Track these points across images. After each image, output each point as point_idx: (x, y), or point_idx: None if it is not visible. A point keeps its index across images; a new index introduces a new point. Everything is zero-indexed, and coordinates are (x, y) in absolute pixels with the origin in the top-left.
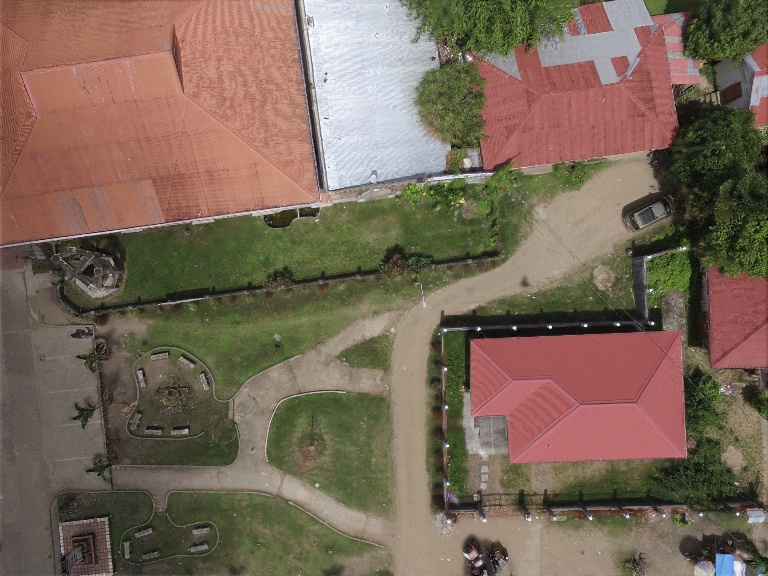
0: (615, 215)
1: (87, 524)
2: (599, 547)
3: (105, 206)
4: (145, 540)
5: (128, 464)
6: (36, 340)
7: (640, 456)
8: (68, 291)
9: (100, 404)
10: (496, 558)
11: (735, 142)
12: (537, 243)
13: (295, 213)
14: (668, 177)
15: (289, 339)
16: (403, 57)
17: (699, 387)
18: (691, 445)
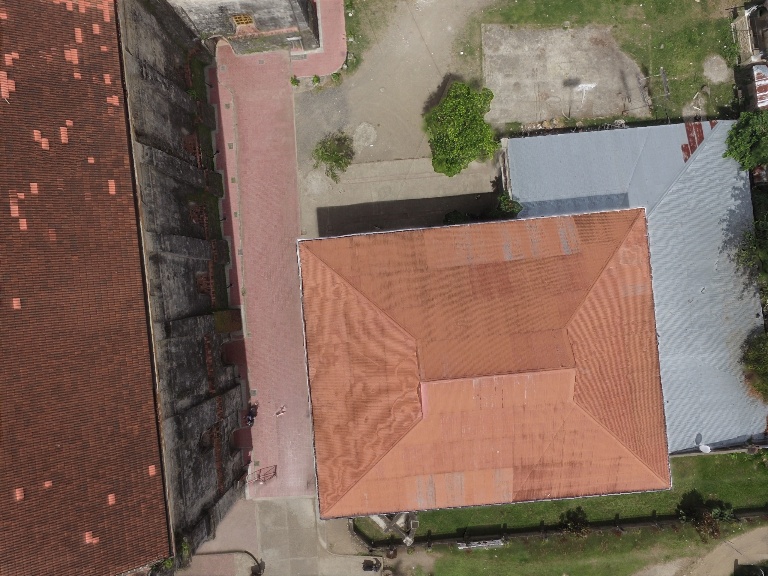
0: None
1: None
2: None
3: (459, 487)
4: None
5: None
6: (323, 568)
7: None
8: (358, 520)
9: None
10: None
11: None
12: None
13: None
14: None
15: None
16: (730, 315)
17: None
18: None
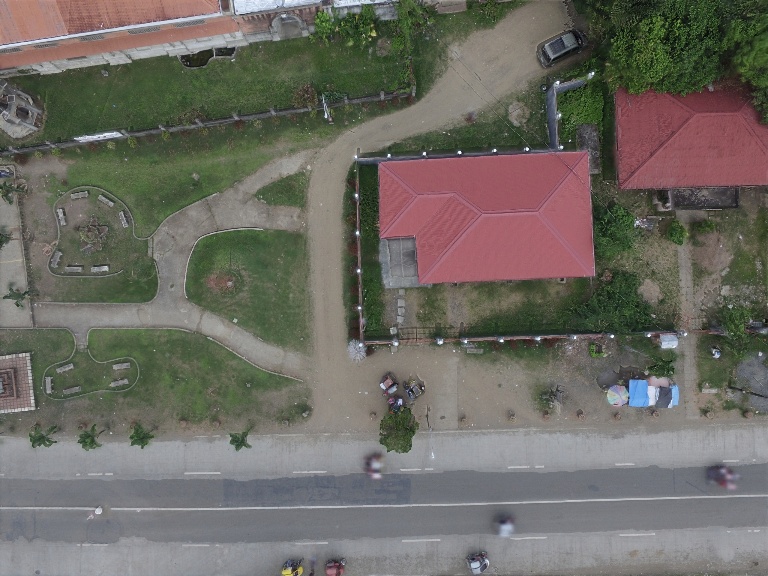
0: (530, 53)
1: (9, 359)
2: (516, 380)
3: (7, 16)
4: (67, 376)
5: (49, 302)
6: None
7: (548, 275)
8: None
9: (21, 242)
10: (411, 387)
11: None
12: (452, 81)
13: (211, 53)
14: (577, 5)
15: (207, 178)
16: None
17: None
18: (607, 277)
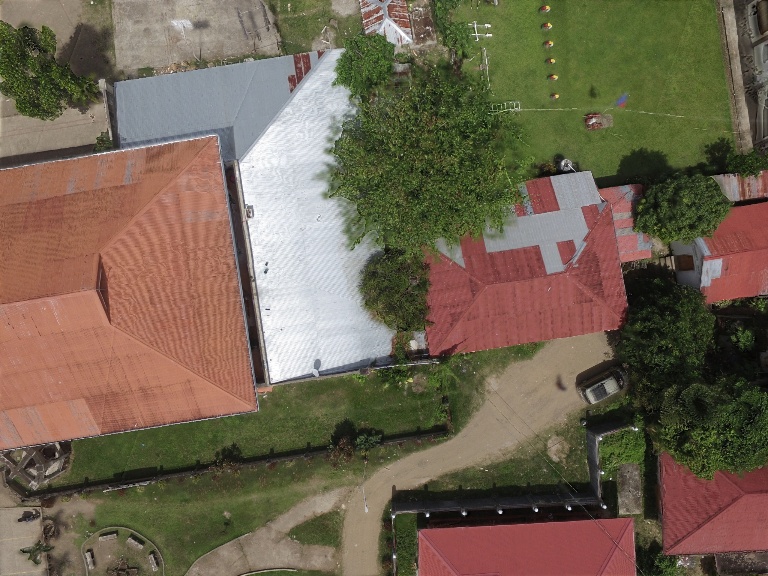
0: (569, 384)
1: None
2: None
3: (39, 423)
4: None
5: None
6: None
7: None
8: None
9: None
10: None
11: (683, 336)
12: (489, 414)
13: None
14: (620, 354)
15: (239, 517)
16: (346, 241)
17: (655, 564)
18: None
